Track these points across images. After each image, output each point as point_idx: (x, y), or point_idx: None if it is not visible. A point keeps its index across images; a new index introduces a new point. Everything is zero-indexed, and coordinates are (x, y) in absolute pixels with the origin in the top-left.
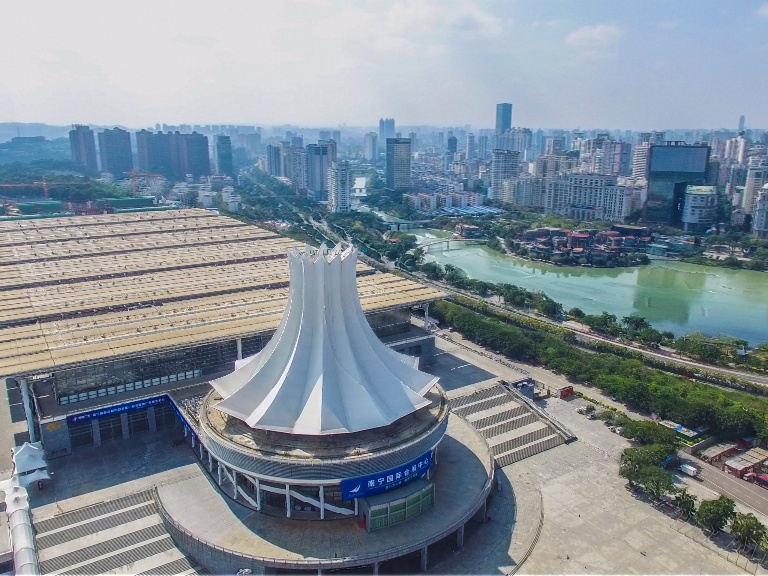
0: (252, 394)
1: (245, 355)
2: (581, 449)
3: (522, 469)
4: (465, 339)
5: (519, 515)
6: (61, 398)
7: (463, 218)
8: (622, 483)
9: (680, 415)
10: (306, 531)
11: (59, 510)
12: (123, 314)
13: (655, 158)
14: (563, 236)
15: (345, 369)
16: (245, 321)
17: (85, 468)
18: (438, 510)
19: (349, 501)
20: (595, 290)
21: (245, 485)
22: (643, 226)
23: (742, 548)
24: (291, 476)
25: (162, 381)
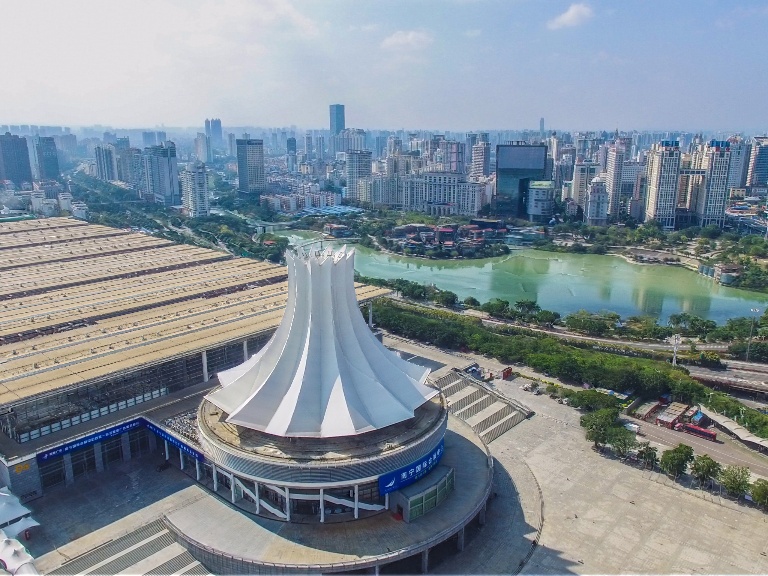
0: (265, 403)
1: (210, 367)
2: (542, 422)
3: (501, 446)
4: (391, 334)
5: (519, 487)
6: (21, 435)
7: (328, 218)
8: (588, 446)
9: (611, 382)
10: (347, 532)
11: (64, 557)
12: (60, 336)
13: (501, 156)
14: (429, 231)
15: (357, 368)
16: (206, 332)
17: (69, 508)
18: (460, 492)
19: (377, 497)
20: (474, 280)
21: (267, 498)
22: (496, 219)
23: (703, 485)
24: (330, 480)
25: (128, 404)
